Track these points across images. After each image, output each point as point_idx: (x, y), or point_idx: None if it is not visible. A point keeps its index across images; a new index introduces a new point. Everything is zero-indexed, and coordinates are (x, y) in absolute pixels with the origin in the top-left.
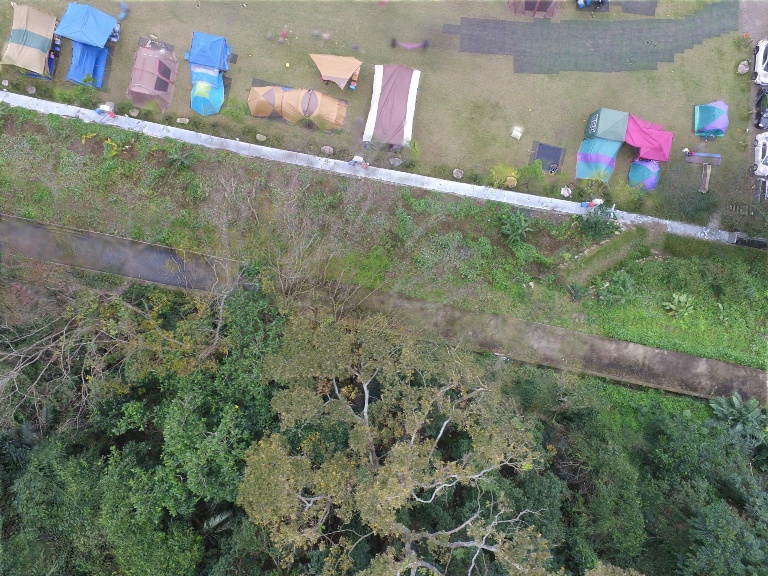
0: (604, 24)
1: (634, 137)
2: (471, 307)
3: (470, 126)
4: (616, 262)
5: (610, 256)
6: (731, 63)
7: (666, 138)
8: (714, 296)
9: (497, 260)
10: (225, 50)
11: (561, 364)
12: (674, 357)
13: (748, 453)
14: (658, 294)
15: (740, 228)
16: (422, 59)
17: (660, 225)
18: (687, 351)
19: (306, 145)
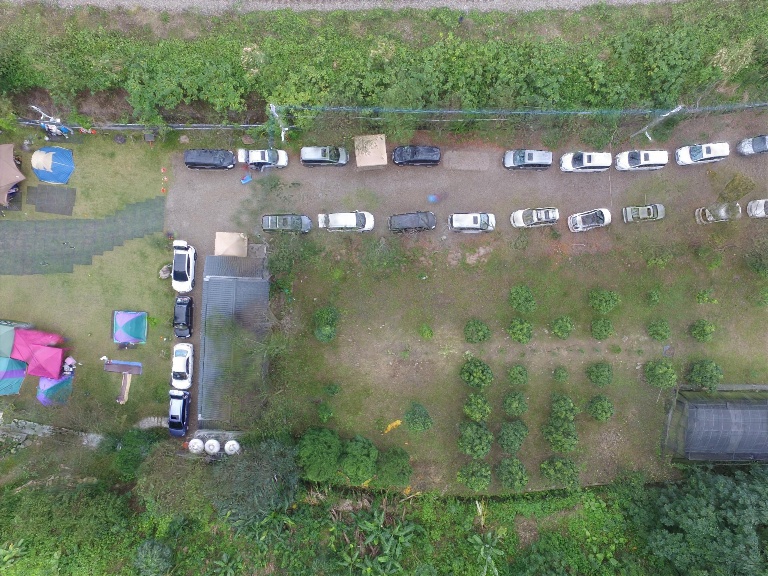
0: (15, 224)
1: (22, 353)
2: None
3: None
4: None
5: None
6: (155, 266)
7: (50, 356)
8: None
9: None
10: None
11: None
12: None
13: None
14: None
15: None
16: None
17: (75, 437)
18: None
19: None
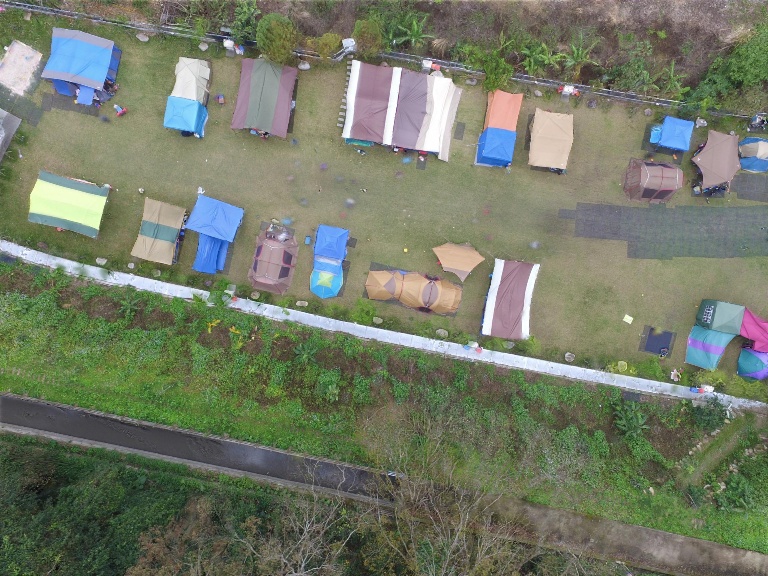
0: (719, 210)
1: (749, 330)
2: (592, 513)
3: (583, 310)
4: (727, 454)
5: (722, 448)
6: None
7: None
8: None
9: (616, 461)
10: None
11: (680, 572)
12: None
13: None
14: None
15: None
16: (537, 244)
17: (767, 410)
18: None
19: (422, 329)
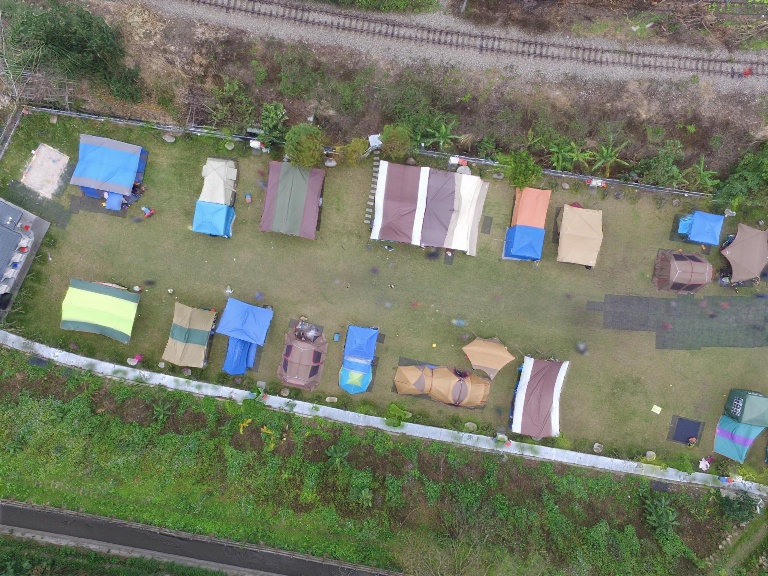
0: (748, 299)
1: None
2: None
3: (611, 401)
4: (756, 545)
5: (751, 540)
6: None
7: None
8: None
9: (647, 559)
10: None
11: None
12: None
13: None
14: None
15: None
16: (565, 336)
17: None
18: None
19: (451, 422)
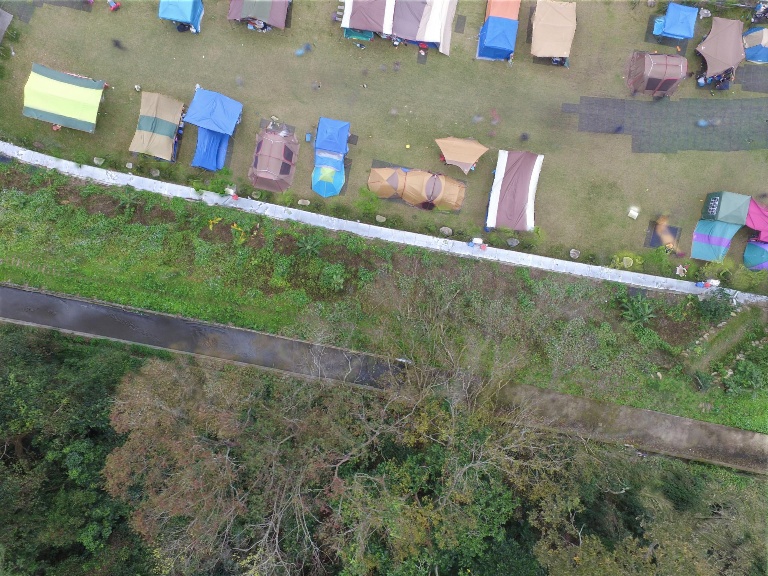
0: (723, 102)
1: (755, 220)
2: (600, 398)
3: (587, 206)
4: (734, 345)
5: (728, 339)
6: None
7: None
8: None
9: (623, 349)
10: None
11: (688, 454)
12: None
13: None
14: None
15: None
16: (541, 139)
17: None
18: None
19: (425, 226)
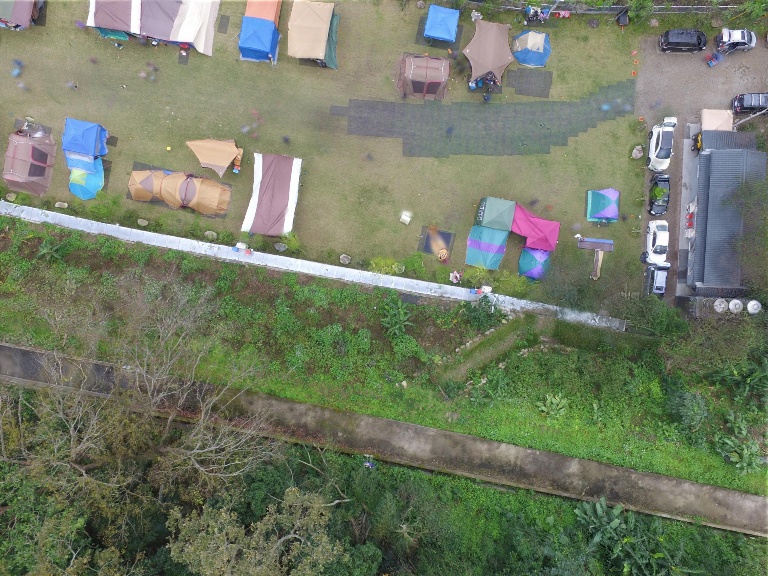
0: (496, 106)
1: (521, 226)
2: (342, 407)
3: (358, 210)
4: (500, 353)
5: (494, 347)
6: (626, 147)
7: (552, 228)
8: (595, 390)
9: (373, 356)
10: (103, 133)
11: (431, 465)
12: (546, 457)
13: (606, 563)
14: (533, 393)
15: (630, 316)
16: (308, 142)
17: (550, 311)
18: (559, 451)
19: (189, 230)
